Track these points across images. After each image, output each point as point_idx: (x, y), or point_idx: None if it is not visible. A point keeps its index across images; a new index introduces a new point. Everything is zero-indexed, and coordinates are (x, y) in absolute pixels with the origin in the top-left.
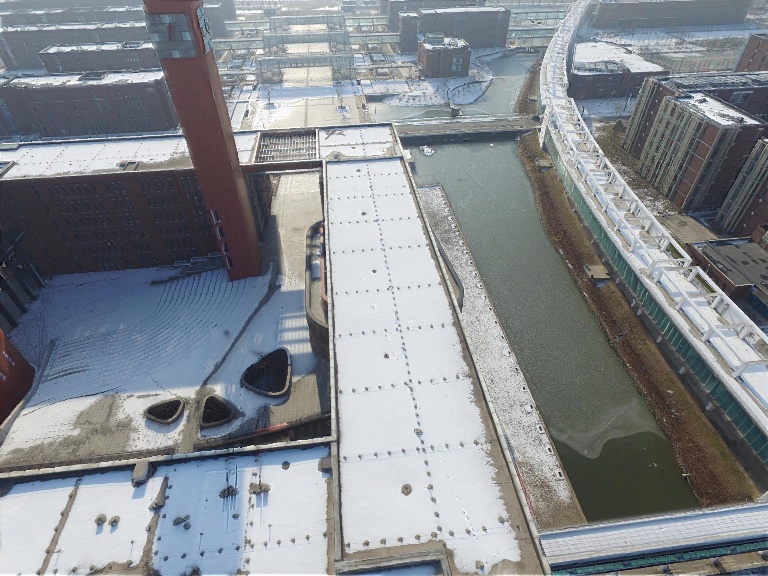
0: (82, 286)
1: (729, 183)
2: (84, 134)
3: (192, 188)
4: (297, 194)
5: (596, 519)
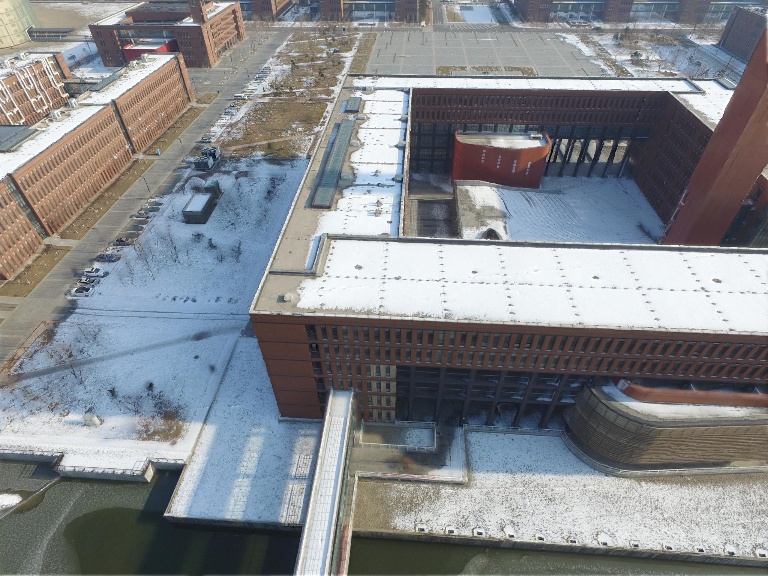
0: (624, 193)
1: None
2: None
3: None
4: None
5: (380, 573)
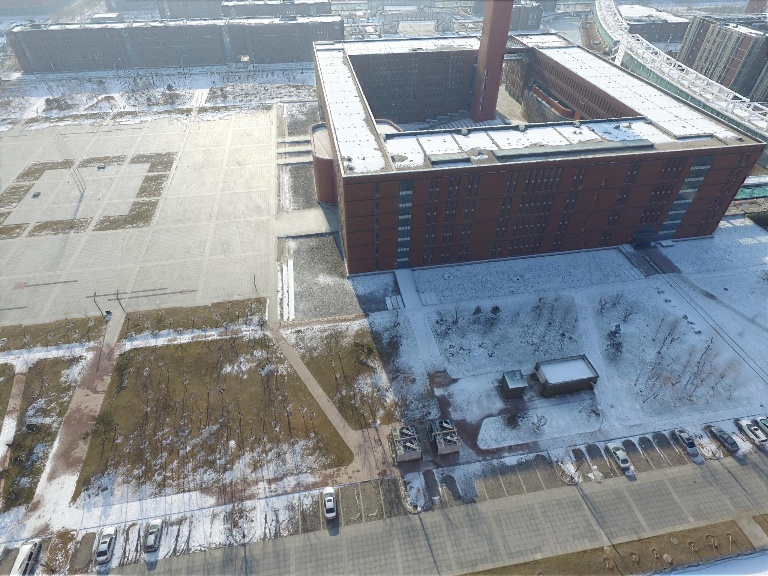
0: None
1: (754, 79)
2: (281, 62)
3: (455, 64)
4: None
5: None
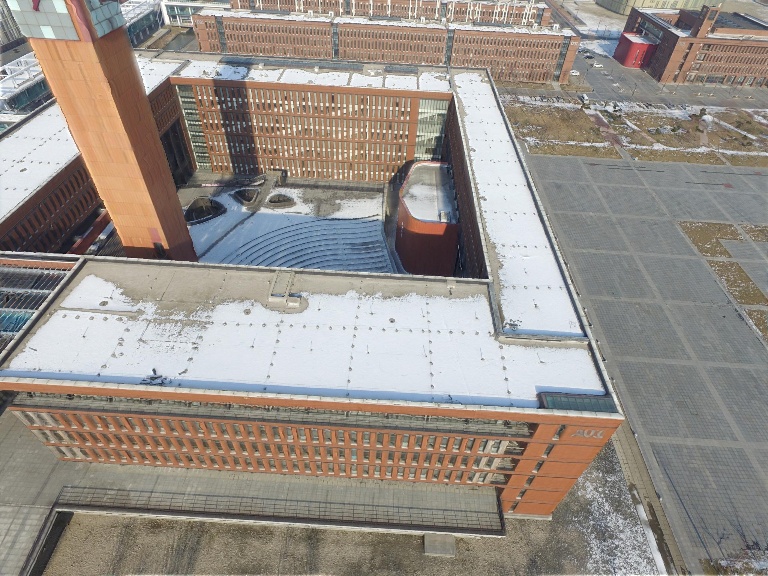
0: None
1: None
2: None
3: None
4: (7, 499)
5: None
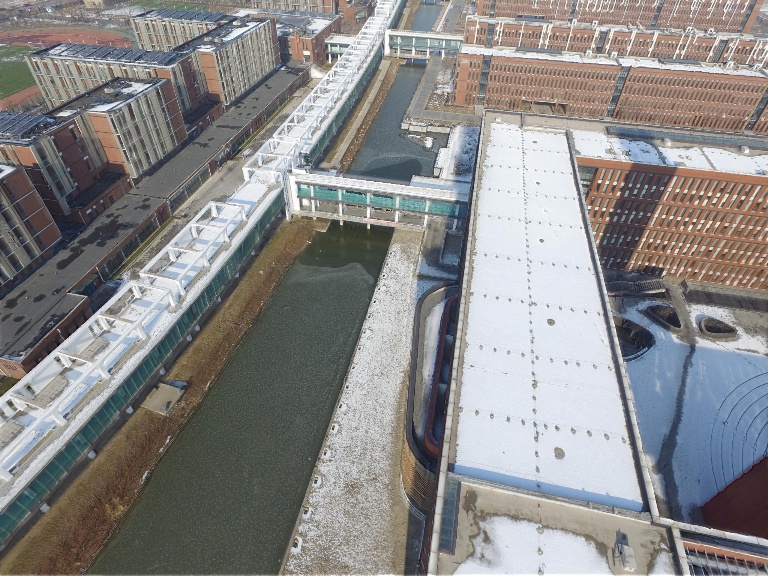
0: None
1: None
2: None
3: None
4: None
5: None
